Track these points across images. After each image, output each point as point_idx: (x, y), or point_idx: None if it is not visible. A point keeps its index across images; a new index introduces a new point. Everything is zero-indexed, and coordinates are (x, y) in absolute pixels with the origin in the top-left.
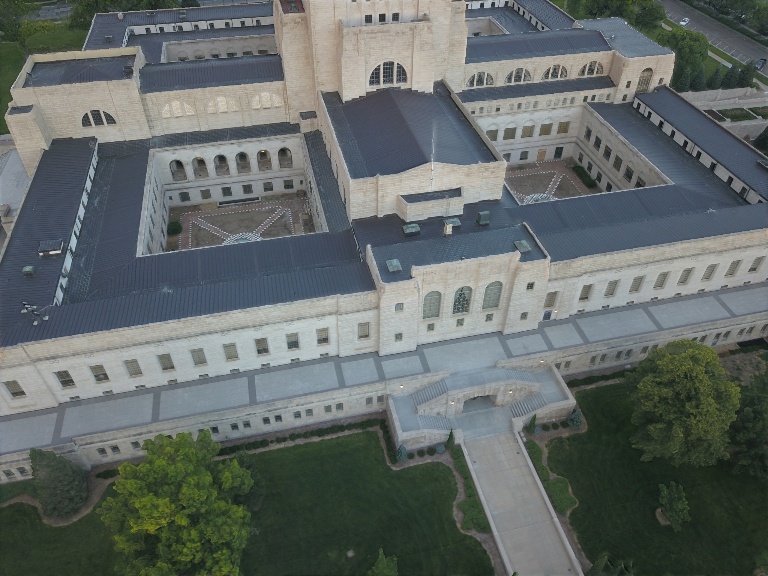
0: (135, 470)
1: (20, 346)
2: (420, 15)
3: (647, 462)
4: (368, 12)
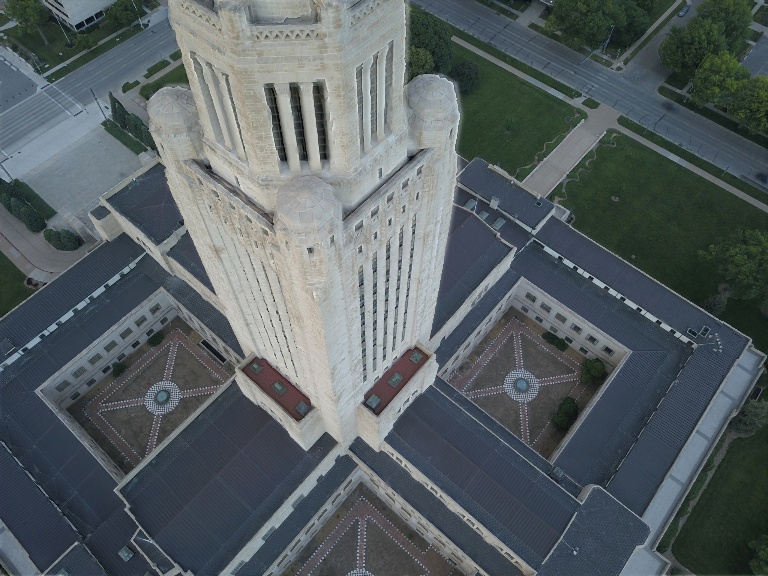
0: None
1: None
2: (312, 404)
3: None
4: (277, 365)
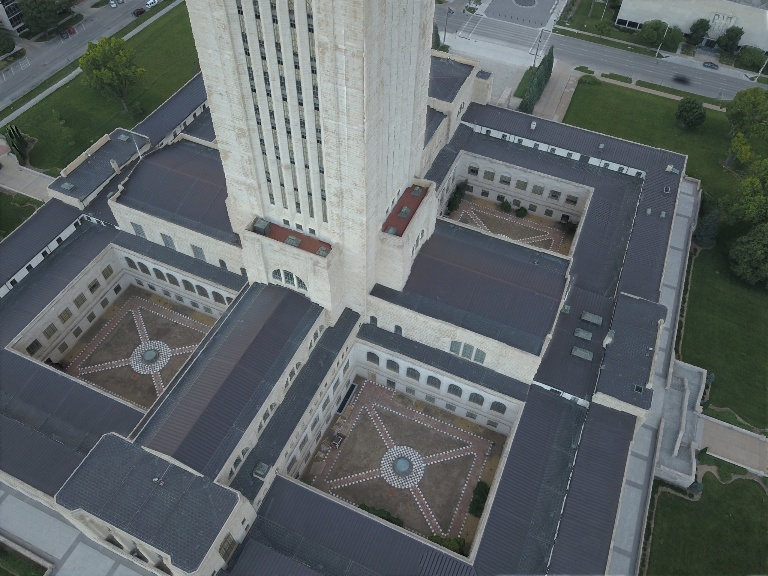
0: (120, 43)
1: None
2: None
3: None
4: None
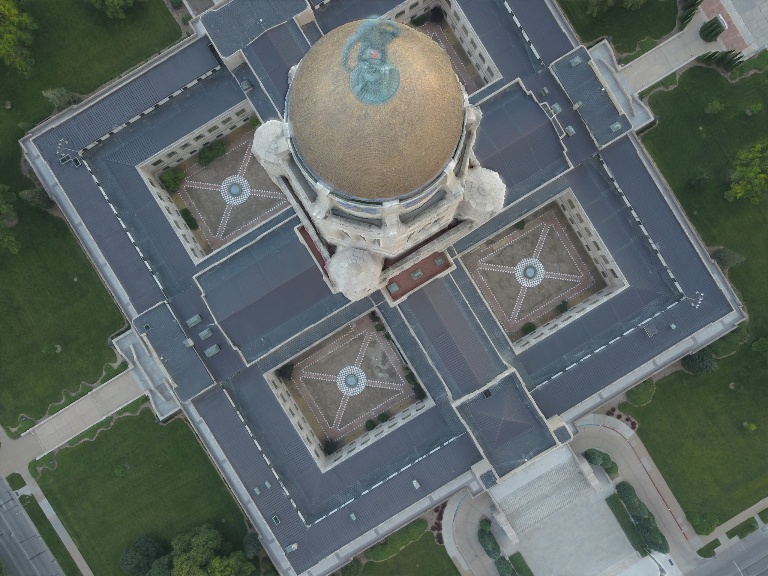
0: None
1: None
2: None
3: (615, 7)
4: None
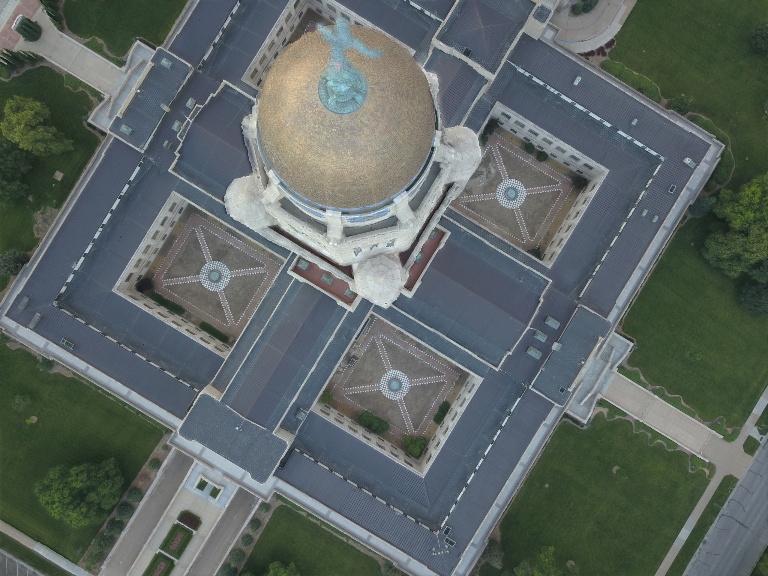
0: None
1: None
2: None
3: None
4: None
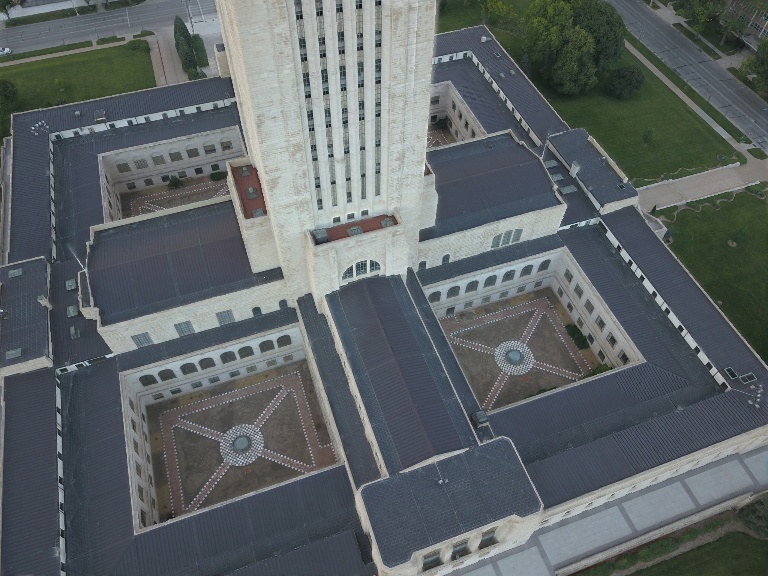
0: None
1: (11, 132)
2: None
3: None
4: None
